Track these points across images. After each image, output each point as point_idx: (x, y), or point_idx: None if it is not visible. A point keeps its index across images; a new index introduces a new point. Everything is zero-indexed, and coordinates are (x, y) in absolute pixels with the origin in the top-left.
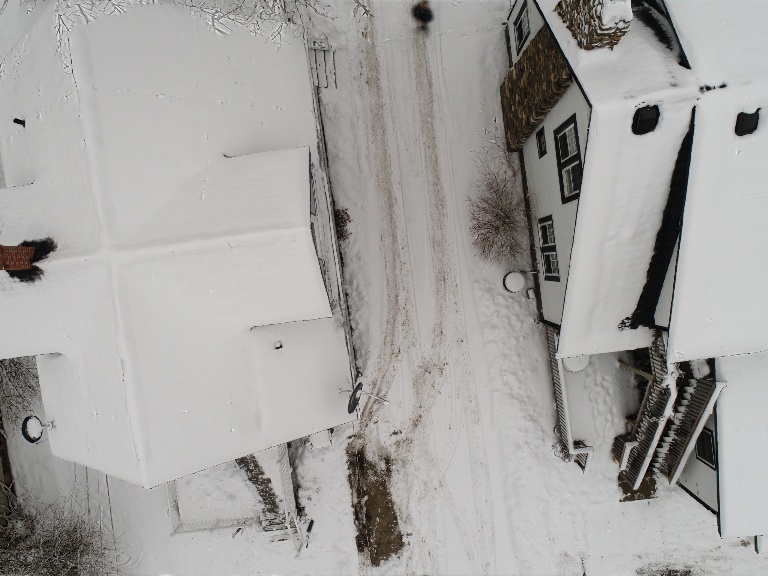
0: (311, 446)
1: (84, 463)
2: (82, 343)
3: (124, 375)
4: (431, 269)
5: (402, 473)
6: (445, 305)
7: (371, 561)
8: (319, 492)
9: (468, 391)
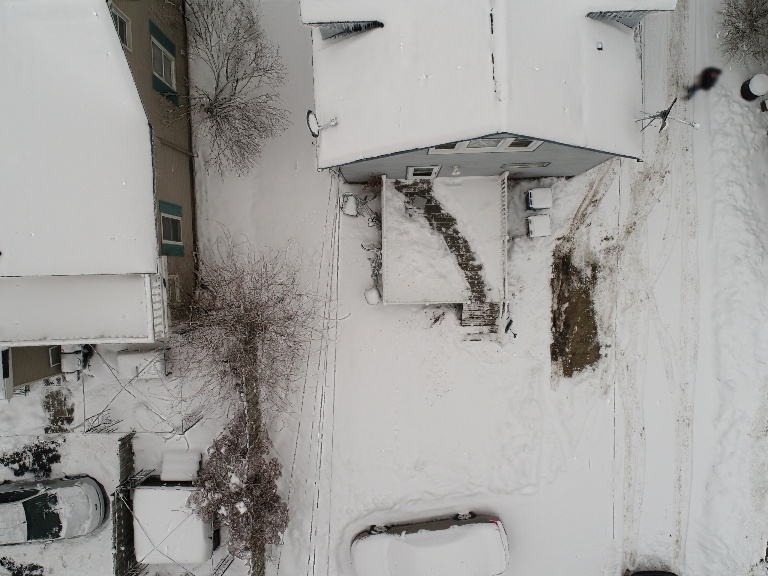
0: (530, 233)
1: (387, 144)
2: (418, 2)
3: (495, 7)
4: (665, 71)
5: (608, 281)
6: (674, 111)
7: (564, 371)
8: (522, 291)
9: (687, 202)
